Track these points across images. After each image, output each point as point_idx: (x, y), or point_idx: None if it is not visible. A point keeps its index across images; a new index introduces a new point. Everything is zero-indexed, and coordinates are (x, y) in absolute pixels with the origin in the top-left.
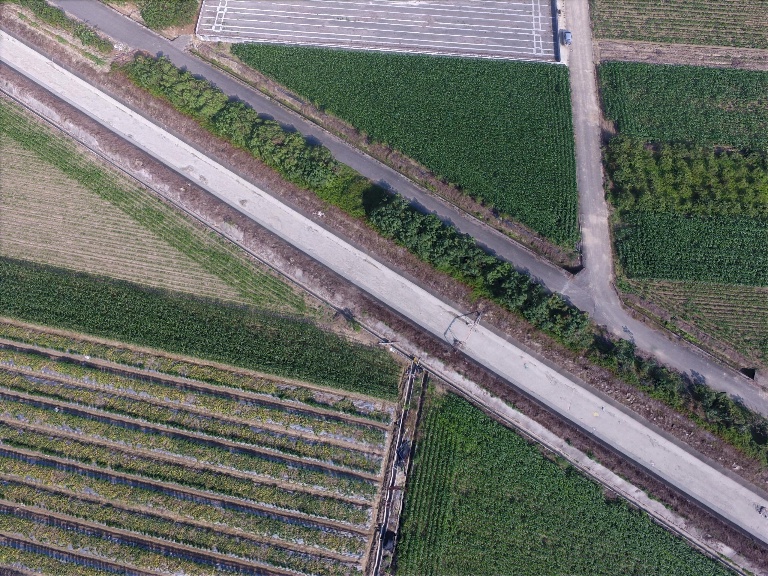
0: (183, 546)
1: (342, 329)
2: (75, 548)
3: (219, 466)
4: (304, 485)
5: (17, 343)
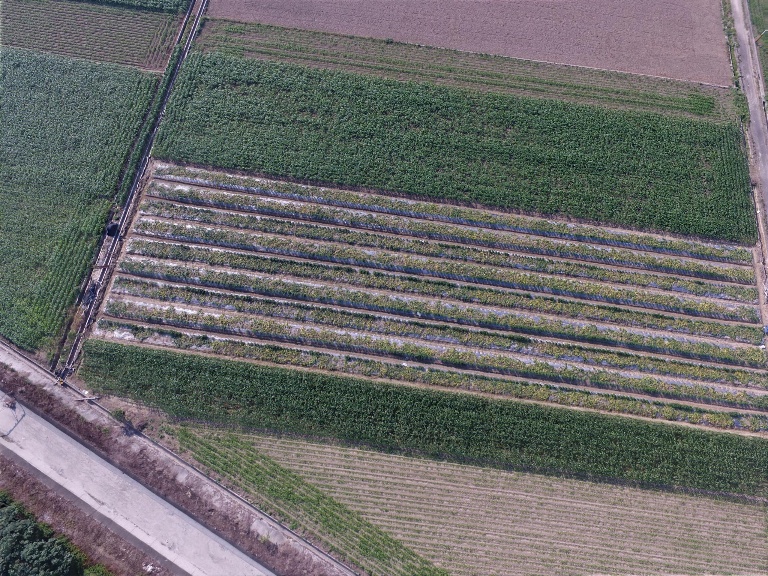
0: (285, 220)
1: (138, 412)
2: (370, 214)
3: (261, 277)
4: (185, 266)
5: (480, 374)
